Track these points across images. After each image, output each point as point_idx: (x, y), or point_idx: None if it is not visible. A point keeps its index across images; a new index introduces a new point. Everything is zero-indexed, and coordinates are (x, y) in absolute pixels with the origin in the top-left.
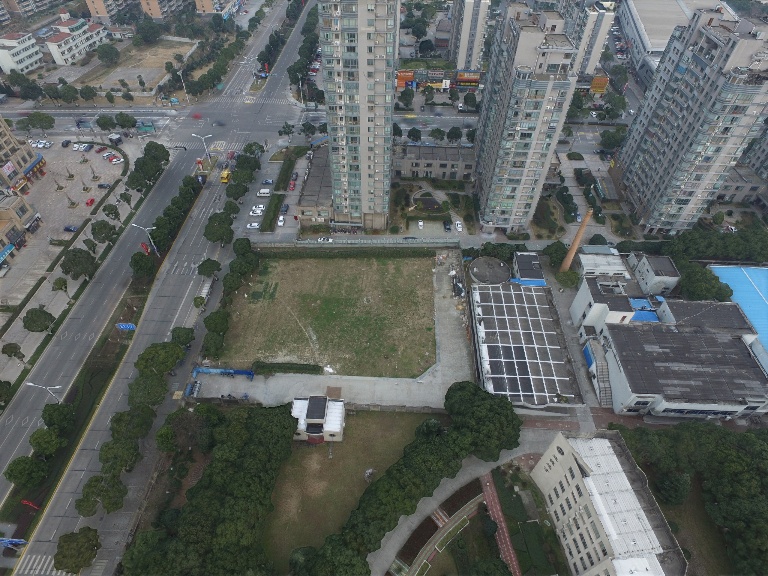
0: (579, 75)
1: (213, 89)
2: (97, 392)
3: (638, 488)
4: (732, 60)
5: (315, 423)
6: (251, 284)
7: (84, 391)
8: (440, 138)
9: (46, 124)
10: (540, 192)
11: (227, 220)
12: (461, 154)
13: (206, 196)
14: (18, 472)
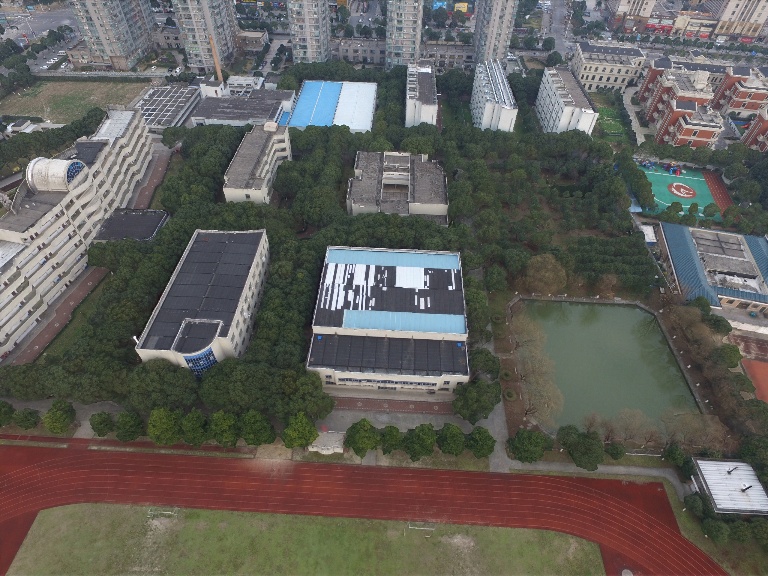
0: None
1: (64, 3)
2: None
3: None
4: None
5: (18, 131)
6: (26, 90)
7: None
8: None
9: None
10: (216, 41)
11: (21, 58)
12: None
13: None
14: None
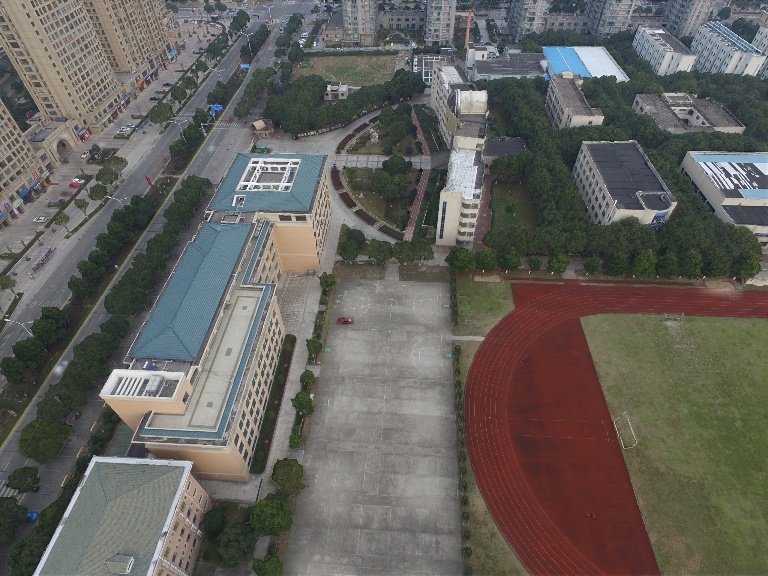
0: None
1: None
2: (234, 90)
3: (461, 75)
4: None
5: (335, 90)
6: (301, 64)
7: (228, 89)
8: None
9: (175, 9)
10: (454, 17)
11: None
12: (418, 14)
13: (272, 38)
14: (212, 95)
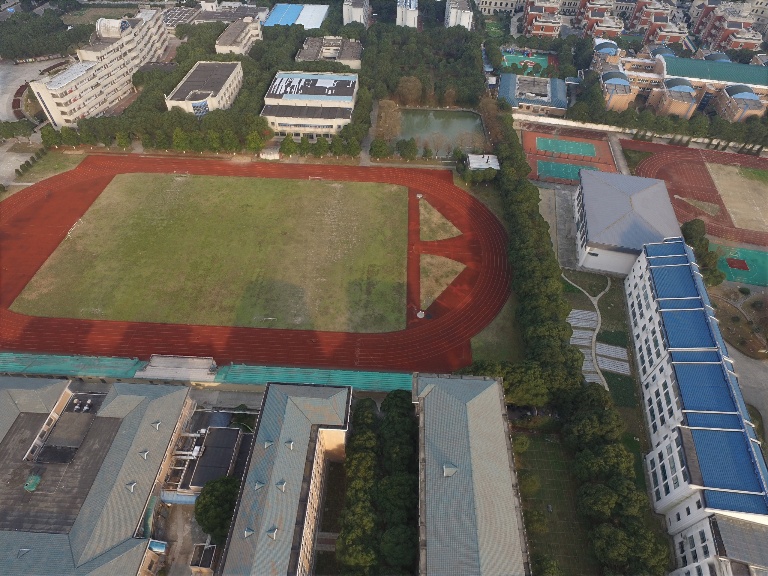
0: None
1: None
2: None
3: None
4: None
5: None
6: (74, 12)
7: None
8: None
9: None
10: None
11: None
12: None
13: None
14: None
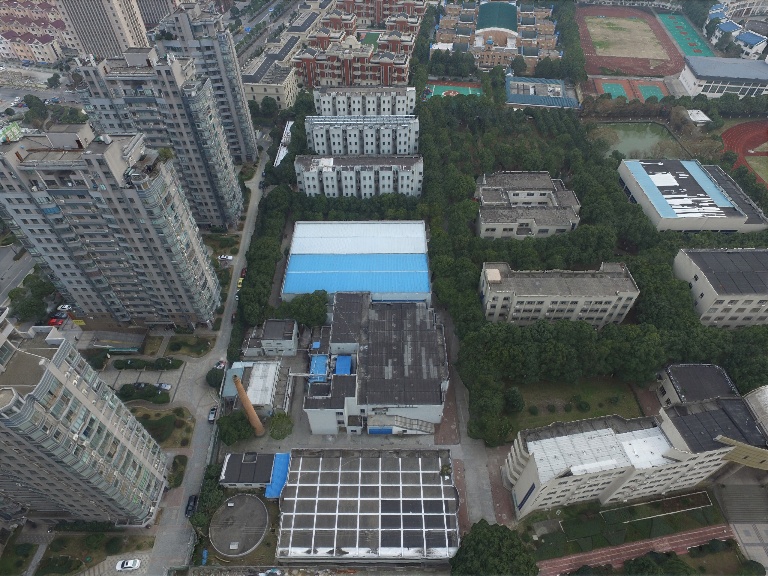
0: None
1: None
2: None
3: (565, 431)
4: (116, 173)
5: None
6: None
7: None
8: None
9: None
10: (141, 427)
11: None
12: None
13: None
14: None
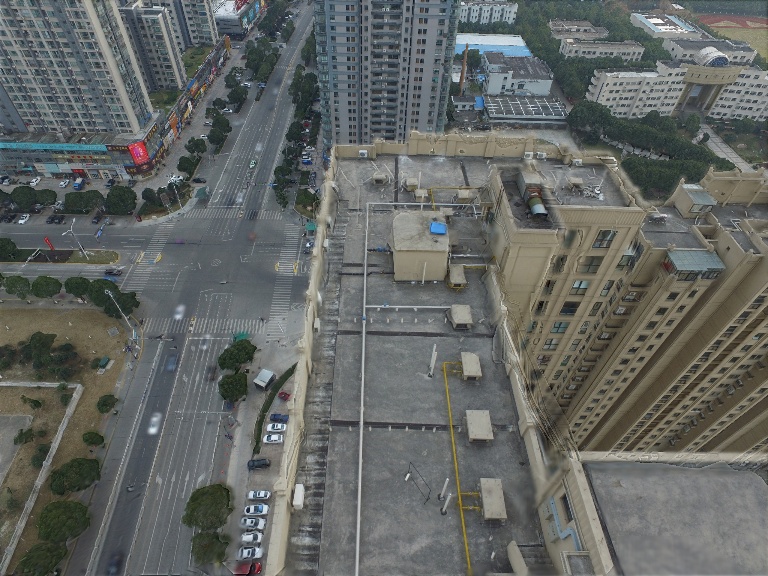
0: (219, 43)
1: None
2: None
3: None
4: None
5: None
6: None
7: None
8: (304, 117)
9: (223, 492)
10: None
11: None
12: None
13: None
14: None
